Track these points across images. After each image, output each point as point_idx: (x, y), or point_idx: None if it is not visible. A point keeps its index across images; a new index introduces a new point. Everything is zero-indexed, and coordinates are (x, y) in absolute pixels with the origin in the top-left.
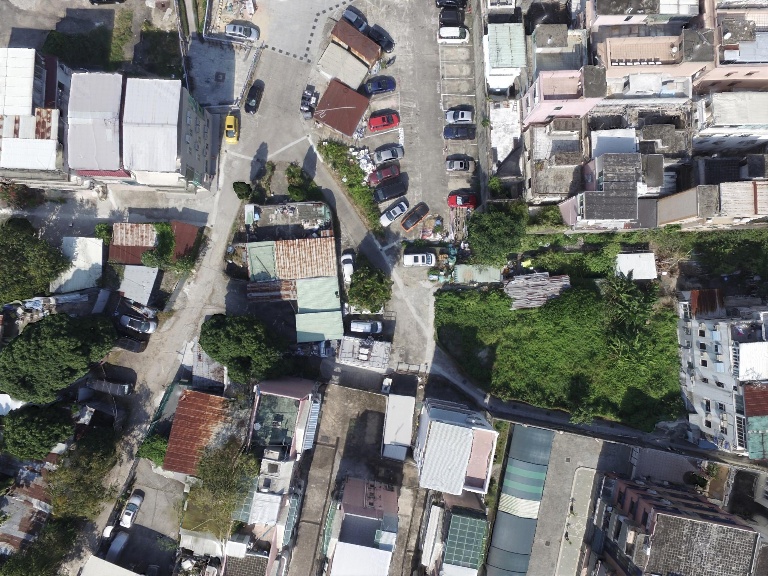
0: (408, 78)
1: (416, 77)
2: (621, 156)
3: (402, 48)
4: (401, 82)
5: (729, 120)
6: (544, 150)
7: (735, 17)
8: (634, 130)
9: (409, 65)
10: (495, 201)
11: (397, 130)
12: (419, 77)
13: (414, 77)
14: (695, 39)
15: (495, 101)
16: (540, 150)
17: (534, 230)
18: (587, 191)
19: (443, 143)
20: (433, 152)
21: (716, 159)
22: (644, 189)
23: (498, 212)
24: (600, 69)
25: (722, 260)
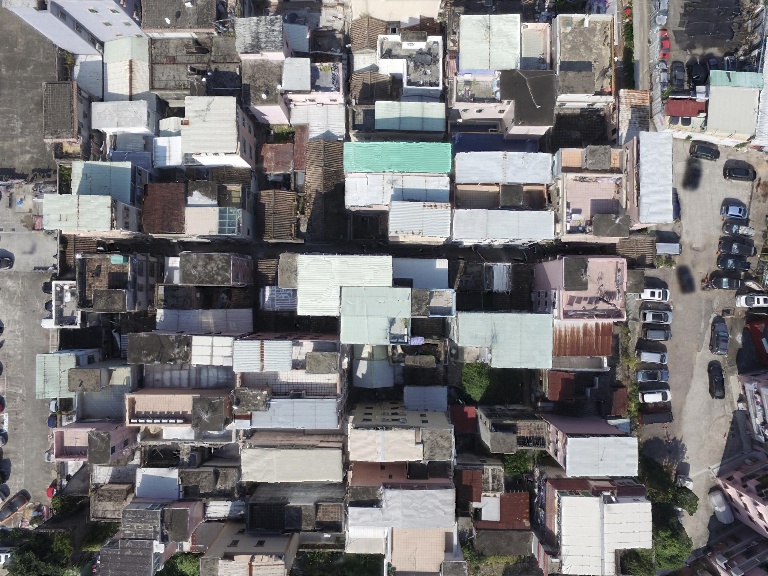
0: (16, 363)
1: (24, 362)
2: (140, 513)
3: (11, 332)
4: (8, 367)
5: (255, 478)
6: (104, 474)
7: (267, 372)
8: (177, 471)
9: (18, 349)
10: (41, 531)
11: (2, 416)
12: (27, 362)
13: (22, 362)
14: (204, 408)
15: (68, 414)
16: (100, 474)
17: (97, 550)
18: (102, 548)
19: (49, 430)
20: (38, 439)
21: (262, 502)
22: (160, 549)
23: (31, 551)
24: (104, 436)
25: (317, 568)
